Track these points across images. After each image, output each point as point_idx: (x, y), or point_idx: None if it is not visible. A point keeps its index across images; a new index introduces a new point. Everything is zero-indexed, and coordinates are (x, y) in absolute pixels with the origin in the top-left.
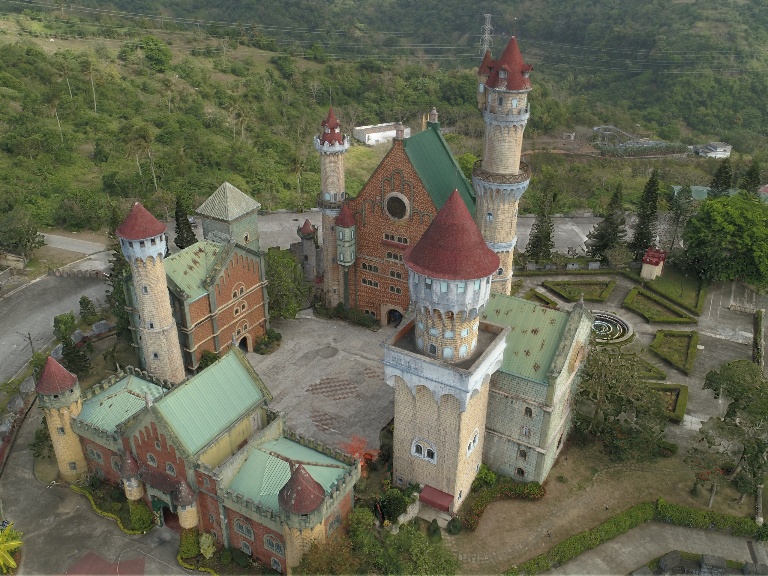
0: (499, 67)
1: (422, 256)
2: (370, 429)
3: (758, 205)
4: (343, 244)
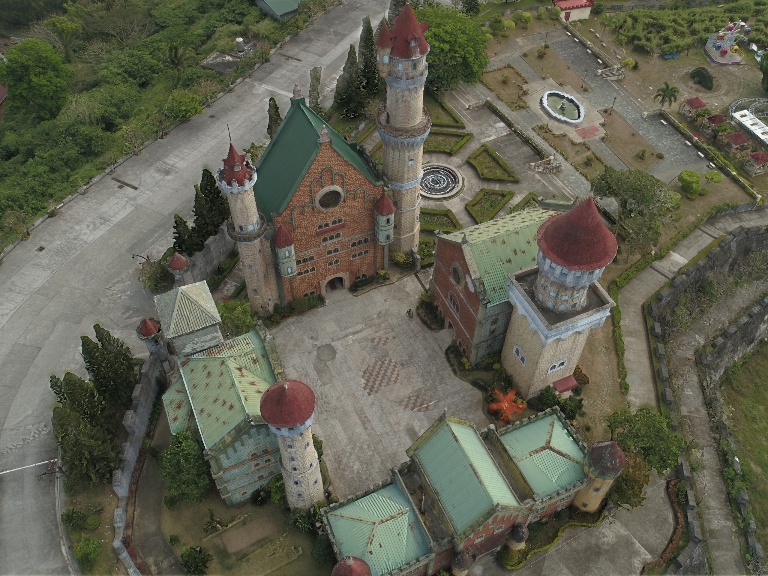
0: (409, 38)
1: (583, 257)
2: (447, 380)
3: (439, 14)
4: (290, 260)
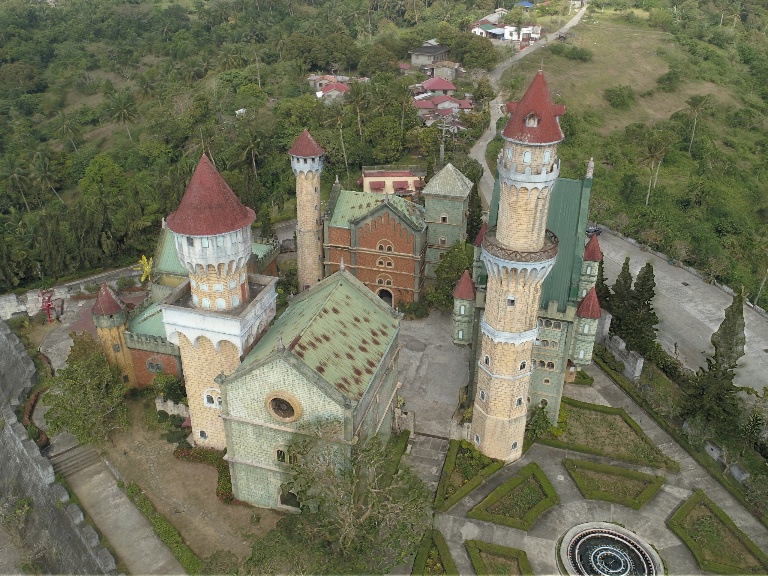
0: None
1: None
2: None
3: None
4: None
